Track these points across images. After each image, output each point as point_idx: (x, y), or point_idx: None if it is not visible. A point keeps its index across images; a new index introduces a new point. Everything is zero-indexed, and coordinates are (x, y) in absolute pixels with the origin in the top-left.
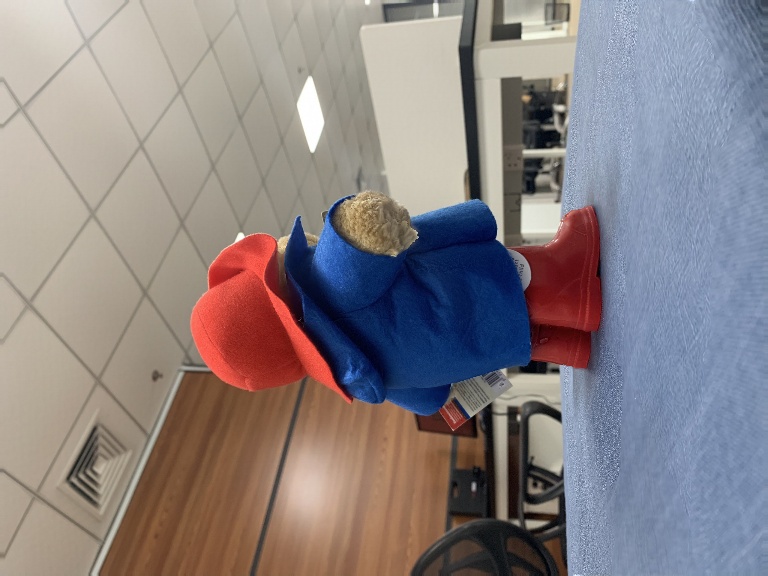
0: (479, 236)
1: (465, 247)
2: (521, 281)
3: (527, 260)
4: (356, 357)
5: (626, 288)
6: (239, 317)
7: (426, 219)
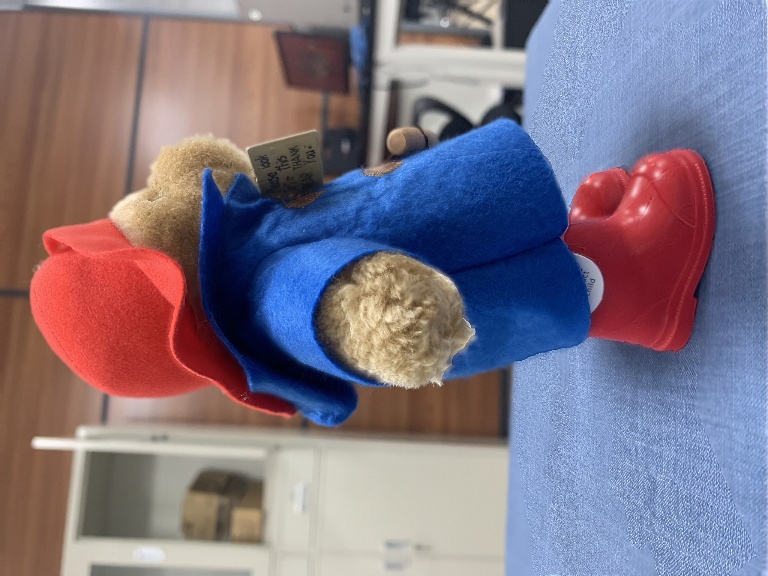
0: (538, 241)
1: (517, 268)
2: None
3: (602, 273)
4: (330, 408)
5: None
6: (125, 345)
7: (454, 211)
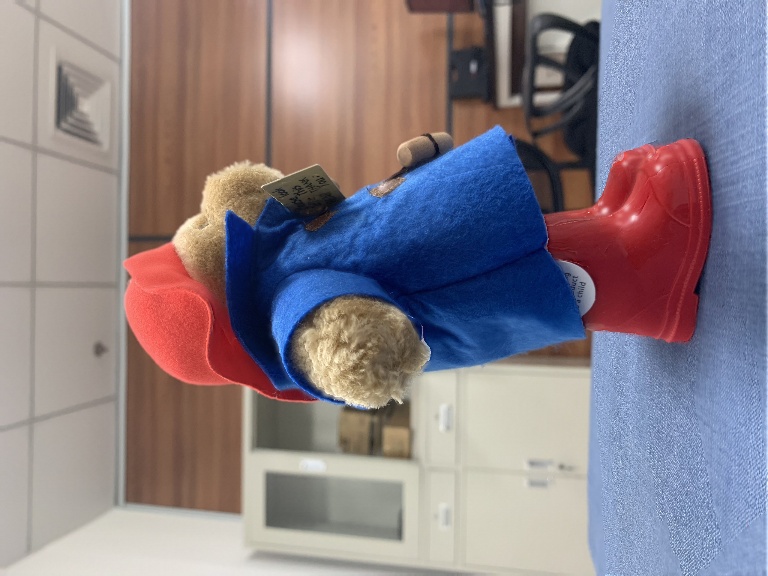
0: (518, 254)
1: (498, 281)
2: (580, 305)
3: (591, 277)
4: None
5: (762, 522)
6: (190, 350)
7: (433, 235)
